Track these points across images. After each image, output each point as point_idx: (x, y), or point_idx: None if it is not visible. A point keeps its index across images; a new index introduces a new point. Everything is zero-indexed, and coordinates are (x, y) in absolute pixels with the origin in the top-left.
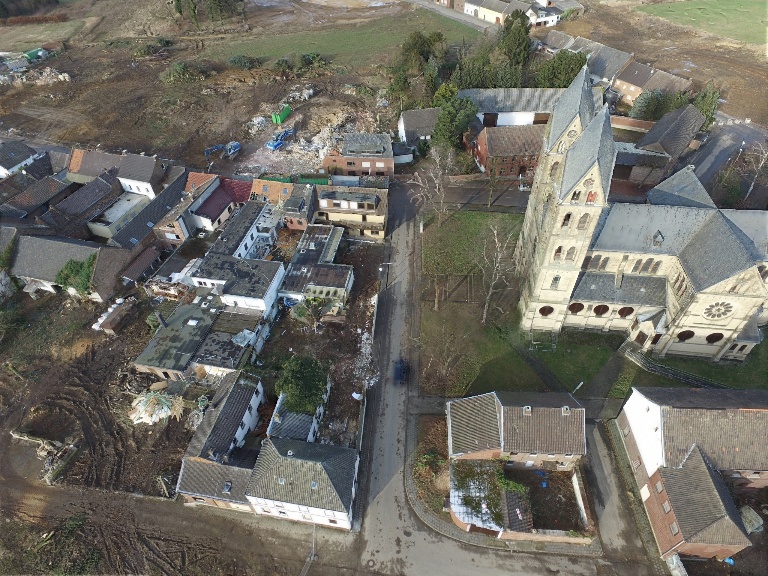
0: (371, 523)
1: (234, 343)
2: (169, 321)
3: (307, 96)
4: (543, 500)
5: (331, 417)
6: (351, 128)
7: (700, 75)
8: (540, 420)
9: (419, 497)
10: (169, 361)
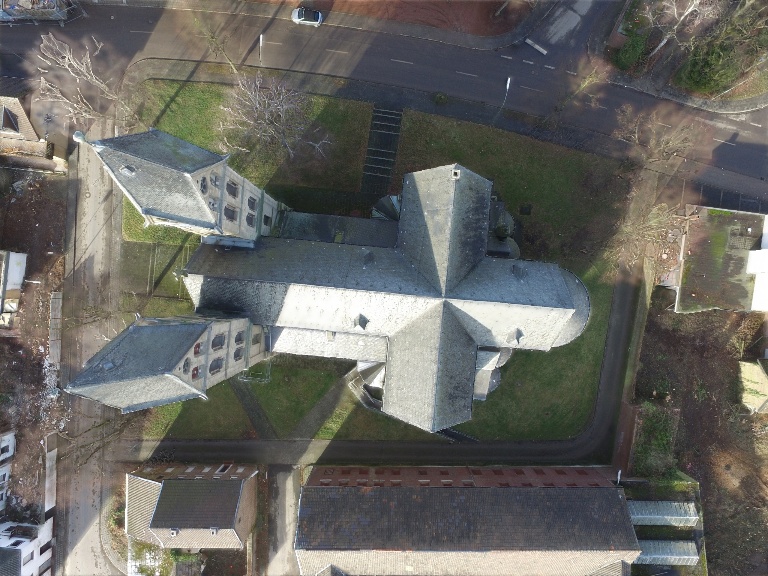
0: (71, 571)
1: None
2: None
3: None
4: (223, 549)
5: (20, 471)
6: None
7: None
8: (191, 534)
9: (112, 548)
10: None
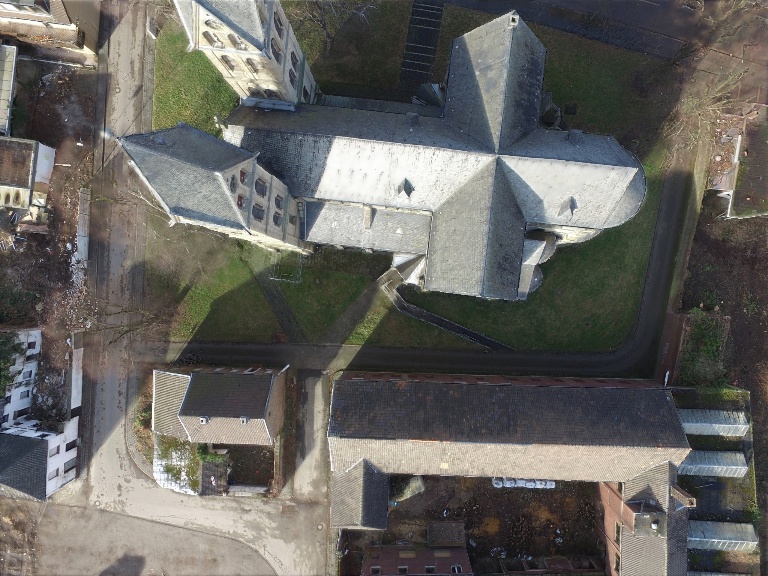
0: (95, 472)
1: None
2: None
3: None
4: (250, 454)
5: (46, 369)
6: None
7: None
8: (221, 425)
9: (137, 450)
10: None
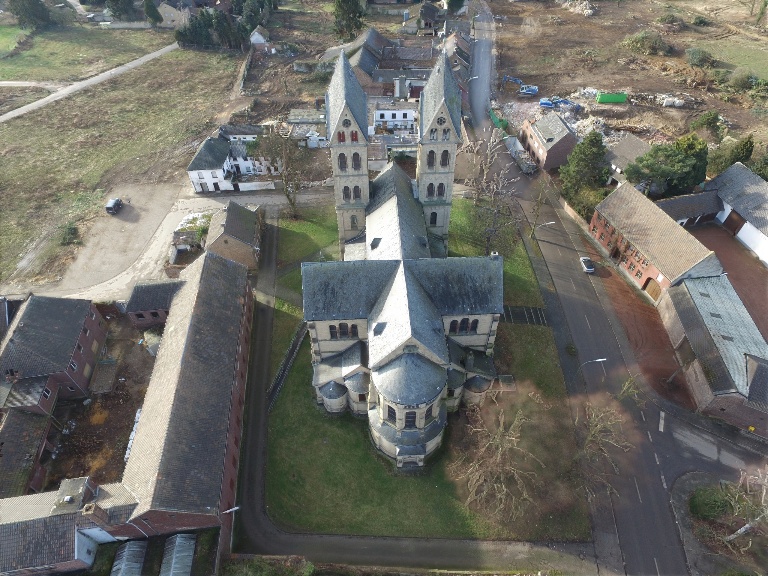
0: None
1: (308, 132)
2: (322, 110)
3: (667, 103)
4: None
5: (262, 177)
6: (620, 135)
7: None
8: None
9: None
10: (293, 117)
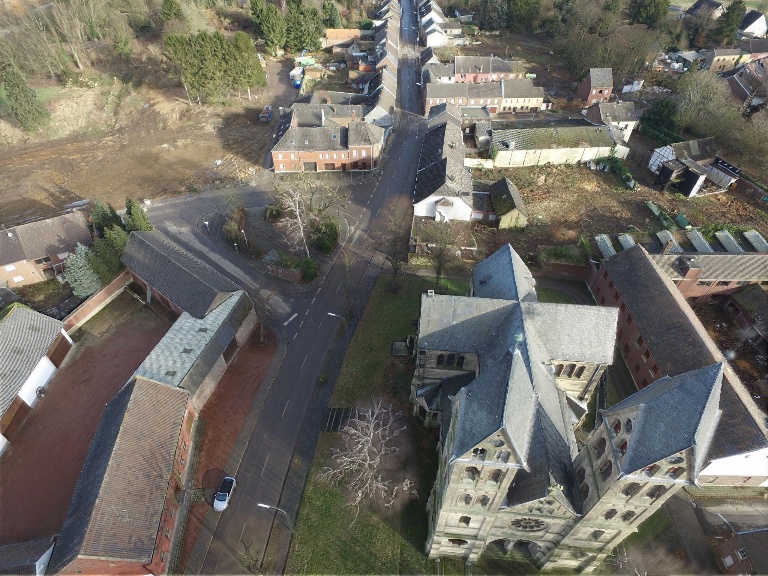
0: None
1: None
2: None
3: None
4: None
5: None
6: None
7: (2, 194)
8: None
9: None
10: None
